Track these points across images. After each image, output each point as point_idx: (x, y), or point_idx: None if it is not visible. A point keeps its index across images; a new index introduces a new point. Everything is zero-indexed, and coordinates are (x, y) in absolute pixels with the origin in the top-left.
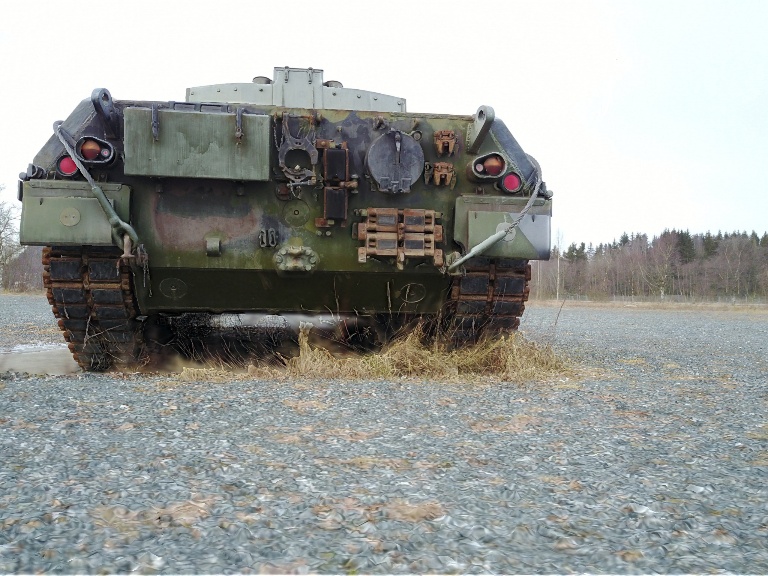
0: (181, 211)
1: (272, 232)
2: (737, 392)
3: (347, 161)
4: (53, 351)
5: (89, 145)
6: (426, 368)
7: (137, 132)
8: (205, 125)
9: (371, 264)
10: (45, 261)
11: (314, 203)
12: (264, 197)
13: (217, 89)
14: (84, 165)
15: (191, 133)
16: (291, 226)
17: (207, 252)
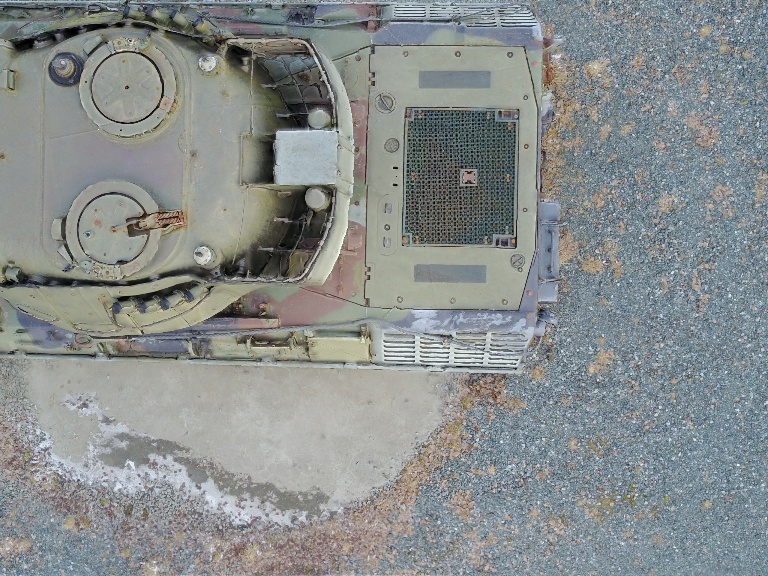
0: None
1: None
2: None
3: None
4: (165, 426)
5: None
6: None
7: None
8: None
9: None
10: None
11: None
12: None
13: None
14: None
15: None
16: None
17: None
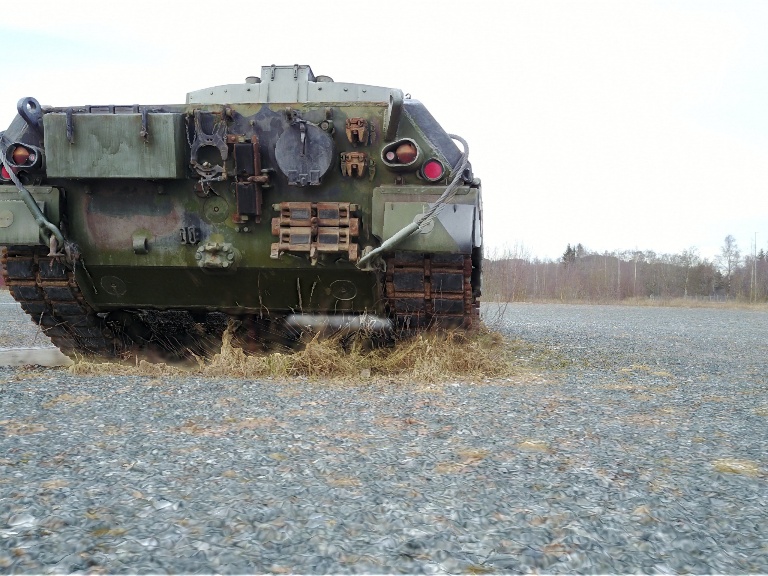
0: (110, 211)
1: (191, 229)
2: (632, 404)
3: (255, 155)
4: None
5: (19, 151)
6: (324, 368)
7: (55, 136)
8: (115, 126)
9: (292, 260)
10: (4, 261)
11: (233, 199)
12: (185, 195)
13: (211, 92)
14: (13, 170)
15: (103, 135)
16: (212, 223)
17: (134, 250)
